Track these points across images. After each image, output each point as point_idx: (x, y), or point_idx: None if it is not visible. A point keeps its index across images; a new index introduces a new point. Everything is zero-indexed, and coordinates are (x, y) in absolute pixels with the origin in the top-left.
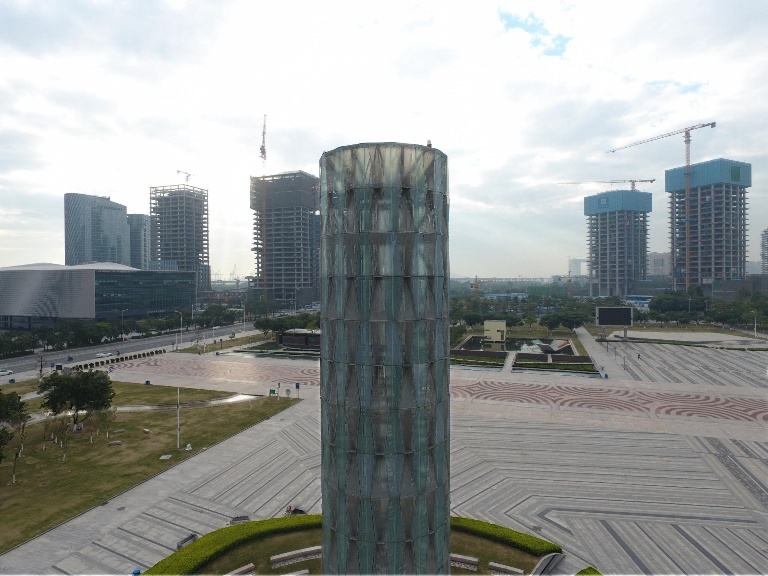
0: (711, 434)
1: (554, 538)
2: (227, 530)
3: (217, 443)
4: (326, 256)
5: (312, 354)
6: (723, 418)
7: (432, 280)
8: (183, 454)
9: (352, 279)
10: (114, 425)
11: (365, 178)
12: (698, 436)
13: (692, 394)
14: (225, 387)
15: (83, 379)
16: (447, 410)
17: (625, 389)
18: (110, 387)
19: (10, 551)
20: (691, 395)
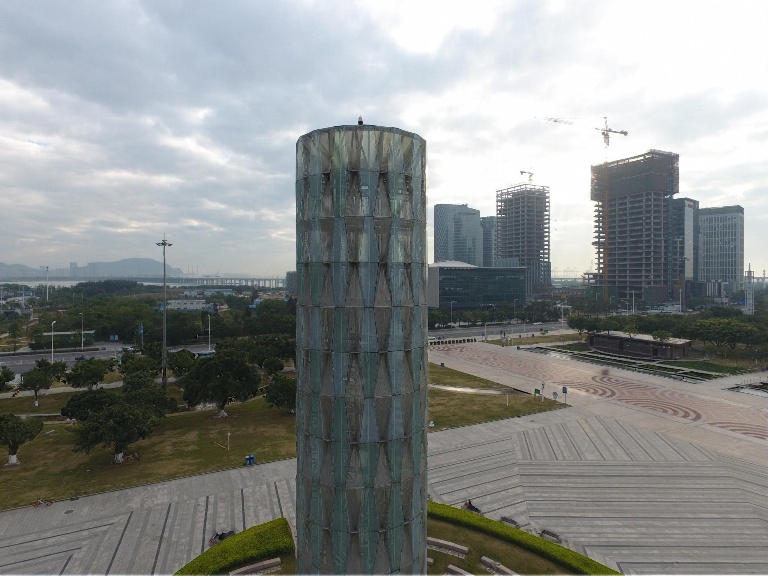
0: None
1: None
2: None
3: (457, 427)
4: None
5: (622, 361)
6: None
7: (357, 266)
8: None
9: None
10: None
11: None
12: None
13: None
14: (502, 379)
15: None
16: (388, 410)
17: None
18: None
19: (285, 460)
20: None
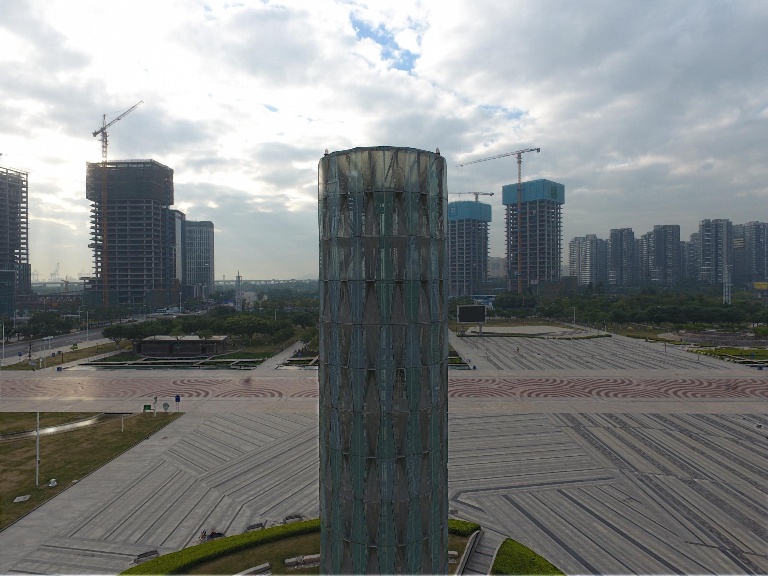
0: (565, 411)
1: (471, 518)
2: (137, 570)
3: (89, 473)
4: (338, 259)
5: (180, 363)
6: (570, 396)
7: (442, 283)
8: (46, 492)
9: (371, 283)
10: None
11: (385, 181)
12: (556, 413)
13: (543, 378)
14: (81, 407)
15: None
16: None
17: (492, 378)
18: None
19: None
20: (542, 379)
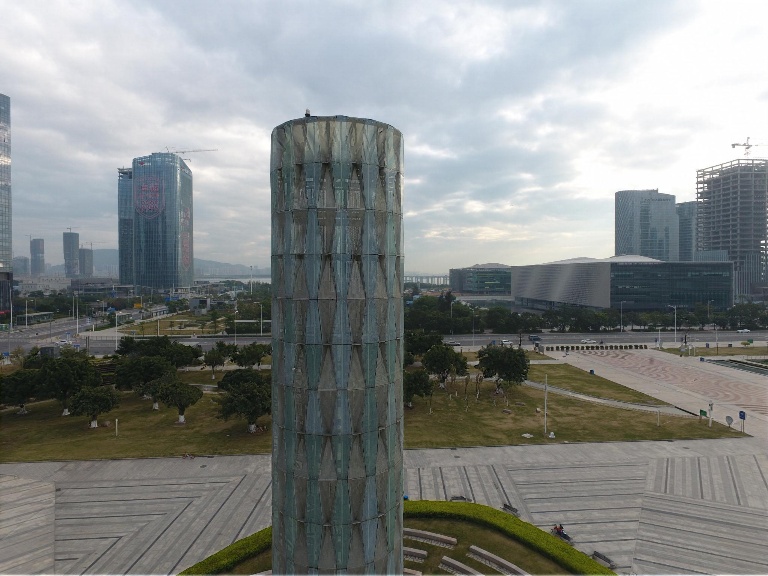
0: None
1: None
2: (482, 508)
3: (583, 442)
4: None
5: None
6: None
7: (302, 258)
8: (543, 439)
9: None
10: (525, 398)
11: None
12: None
13: None
14: (664, 395)
15: (504, 353)
16: (333, 404)
17: None
18: (528, 365)
19: None
20: None
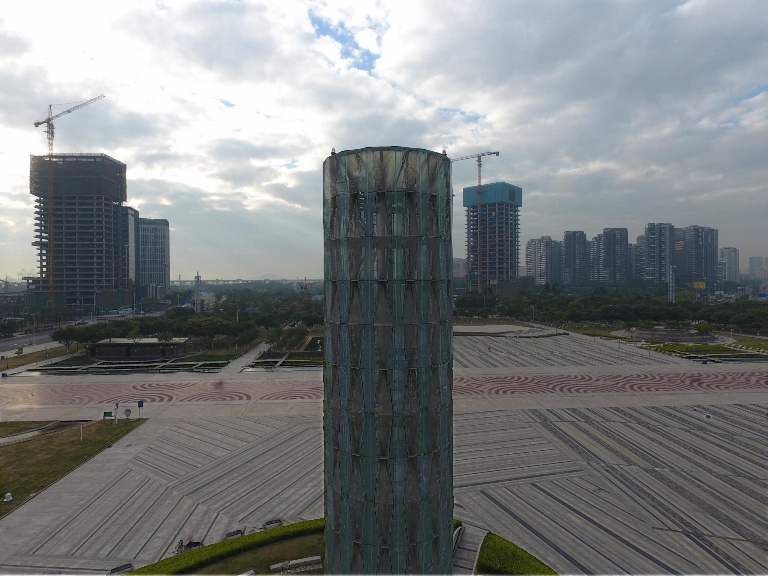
0: (532, 407)
1: None
2: None
3: (48, 485)
4: (348, 259)
5: (139, 367)
6: (535, 393)
7: (449, 284)
8: (1, 507)
9: (383, 283)
10: None
11: (397, 182)
12: (524, 409)
13: (508, 376)
14: (32, 416)
15: None
16: None
17: (460, 376)
18: None
19: None
20: (508, 377)
